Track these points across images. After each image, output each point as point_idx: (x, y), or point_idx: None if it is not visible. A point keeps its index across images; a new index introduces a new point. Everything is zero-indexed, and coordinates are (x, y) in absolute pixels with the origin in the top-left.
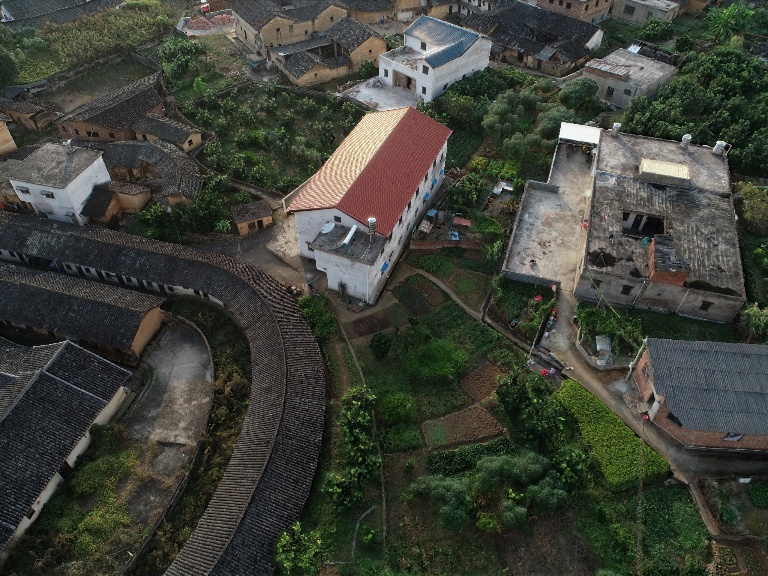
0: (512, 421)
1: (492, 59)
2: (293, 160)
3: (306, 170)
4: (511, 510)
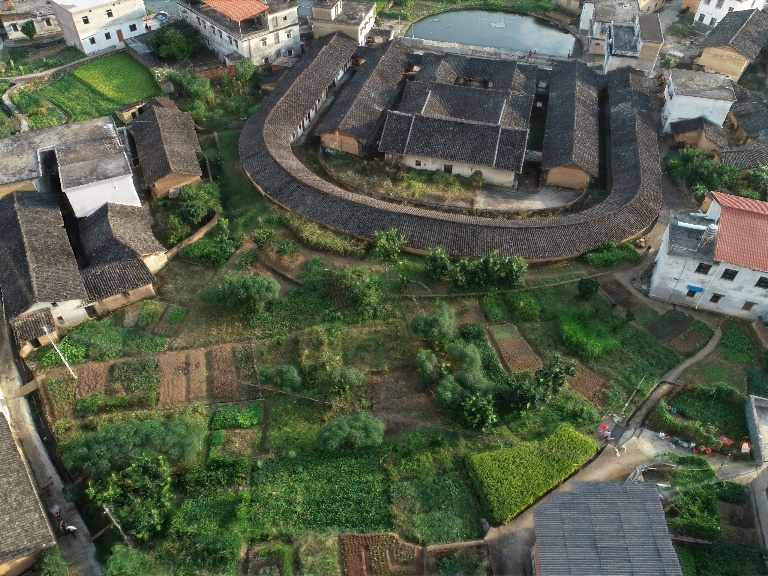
0: None
1: None
2: None
3: None
4: (429, 360)
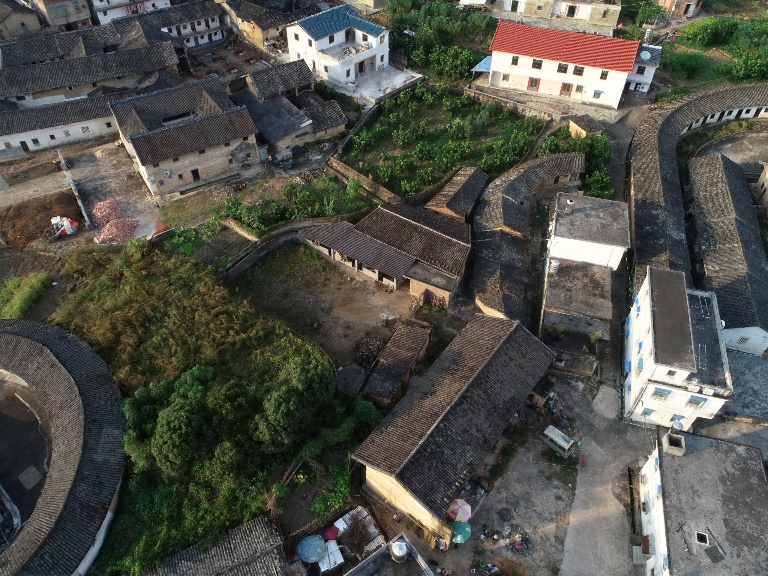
0: (709, 46)
1: None
2: None
3: (494, 124)
4: None
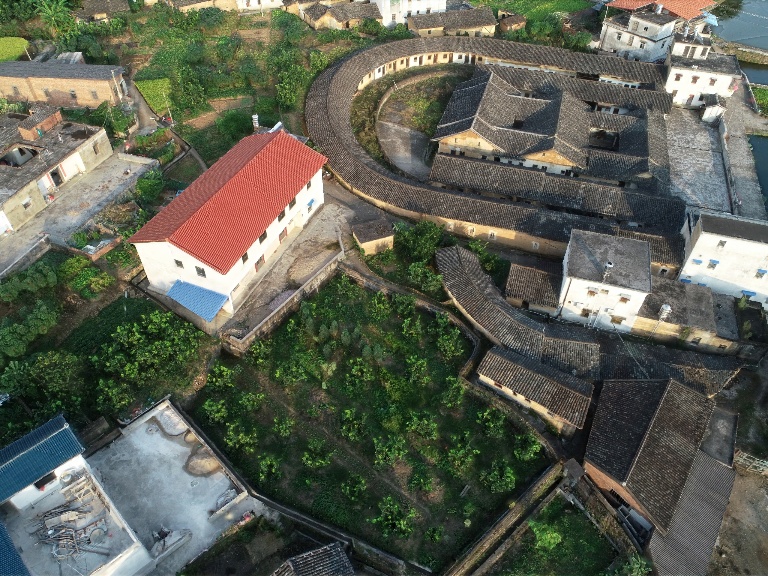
0: None
1: None
2: (340, 346)
3: None
4: None
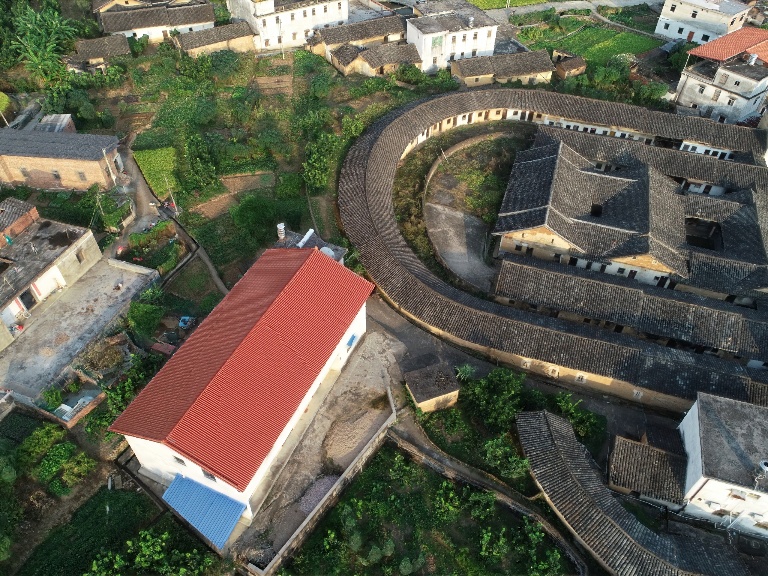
0: None
1: None
2: (395, 569)
3: (369, 536)
4: None
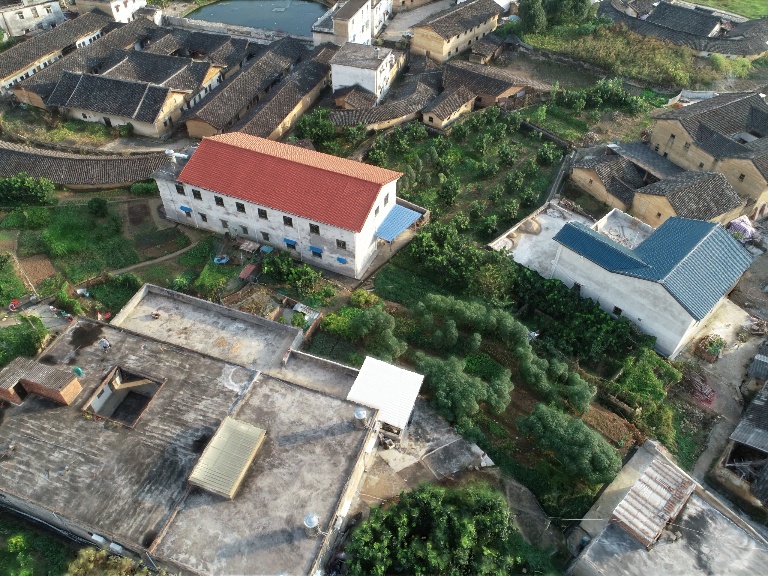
0: None
1: (749, 378)
2: None
3: None
4: None
